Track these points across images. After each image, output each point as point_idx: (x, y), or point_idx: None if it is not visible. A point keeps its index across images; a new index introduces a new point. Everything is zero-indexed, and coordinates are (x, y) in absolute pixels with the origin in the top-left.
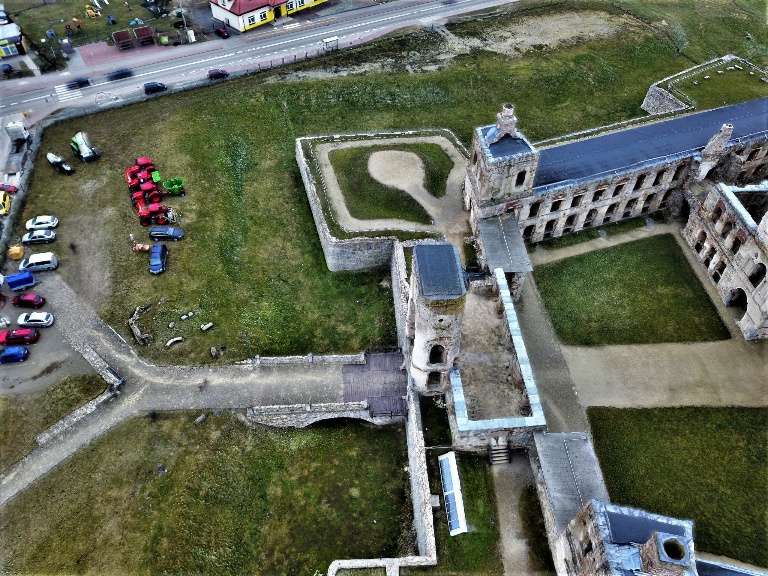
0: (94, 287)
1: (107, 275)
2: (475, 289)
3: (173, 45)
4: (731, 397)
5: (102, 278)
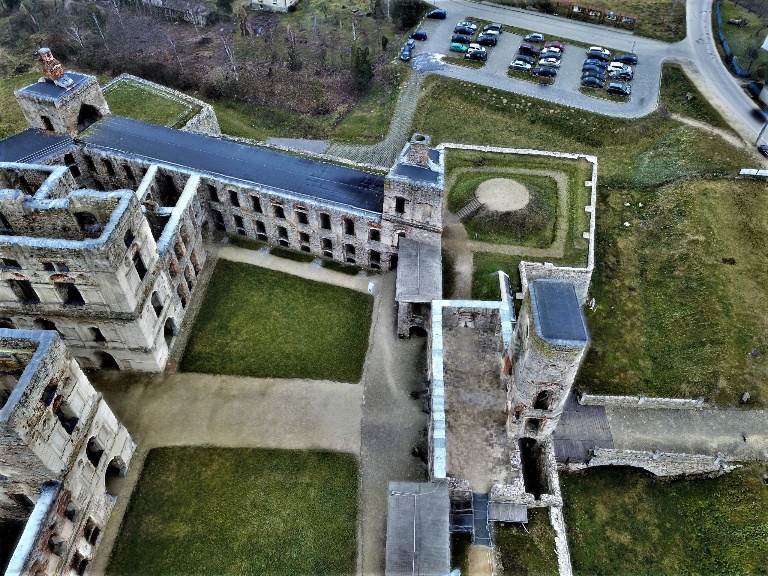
0: None
1: None
2: None
3: None
4: (210, 383)
5: None
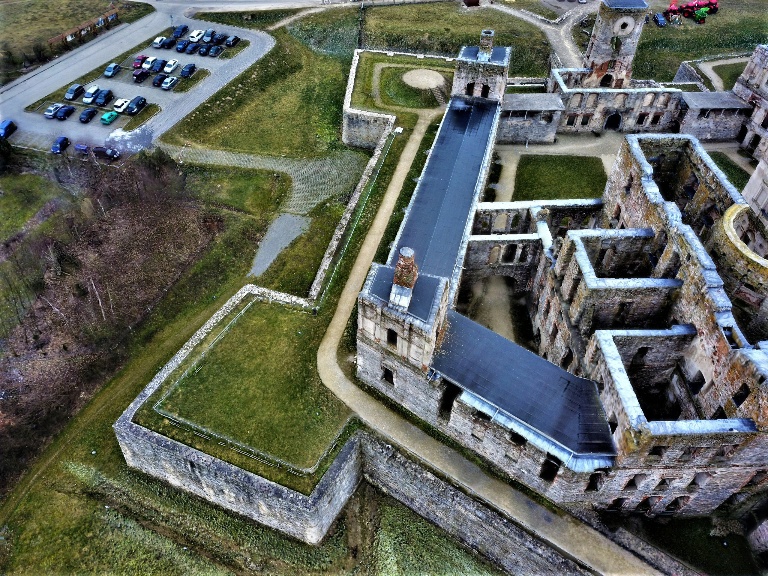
0: None
1: None
2: (665, 96)
3: None
4: None
5: None
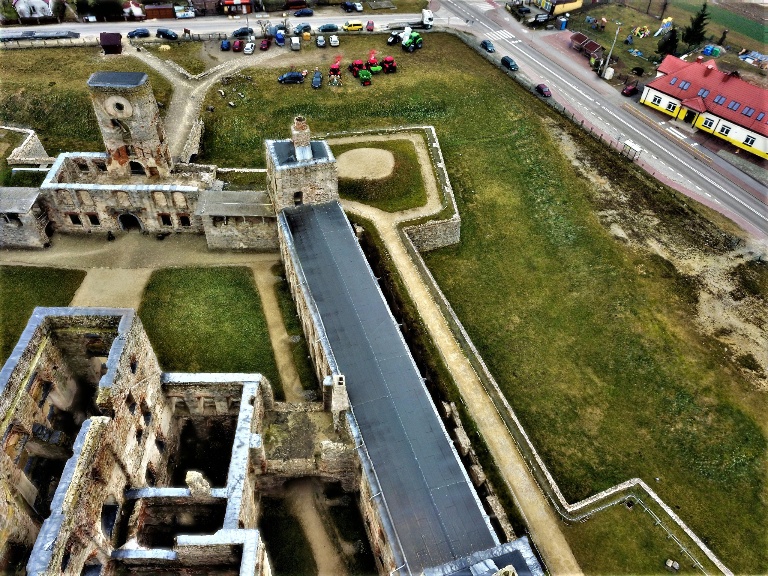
0: (274, 63)
1: (284, 66)
2: None
3: (593, 69)
4: None
5: (281, 65)
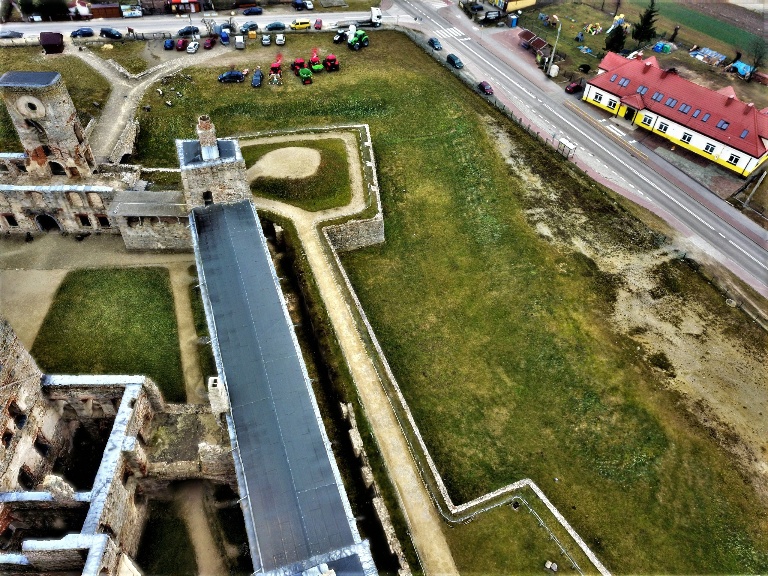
0: (216, 62)
1: (226, 65)
2: None
3: (539, 66)
4: None
5: (224, 64)
